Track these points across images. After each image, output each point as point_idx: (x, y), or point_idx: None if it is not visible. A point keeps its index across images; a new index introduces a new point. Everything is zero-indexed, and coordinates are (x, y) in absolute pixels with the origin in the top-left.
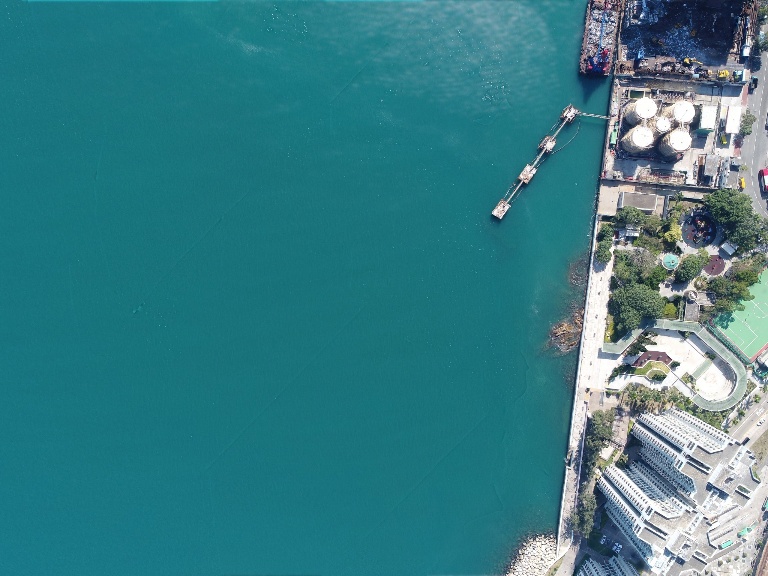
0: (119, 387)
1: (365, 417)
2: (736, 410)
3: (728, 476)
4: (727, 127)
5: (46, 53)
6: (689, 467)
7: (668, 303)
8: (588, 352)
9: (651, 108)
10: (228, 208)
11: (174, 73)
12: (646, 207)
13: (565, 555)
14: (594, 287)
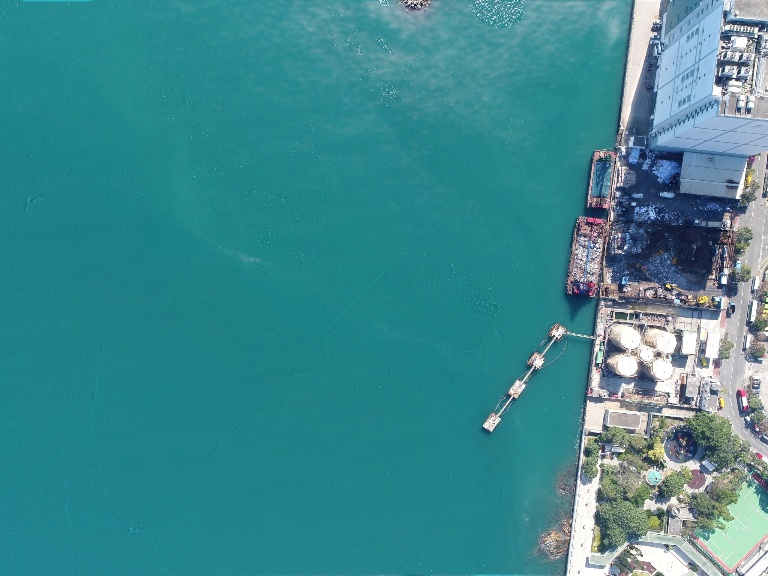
0: None
1: None
2: None
3: None
4: (707, 352)
5: (45, 274)
6: None
7: (652, 516)
8: (576, 561)
9: (635, 339)
10: (225, 432)
11: (171, 276)
12: (631, 426)
13: None
14: (581, 499)
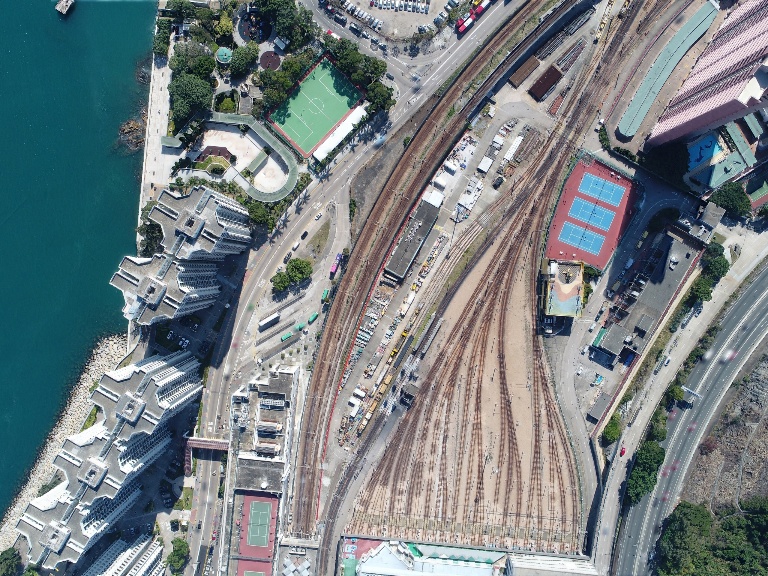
0: None
1: None
2: (294, 204)
3: (188, 218)
4: None
5: None
6: (158, 213)
7: (226, 98)
8: (152, 148)
9: None
10: None
11: None
12: (198, 0)
13: (134, 352)
14: (157, 83)
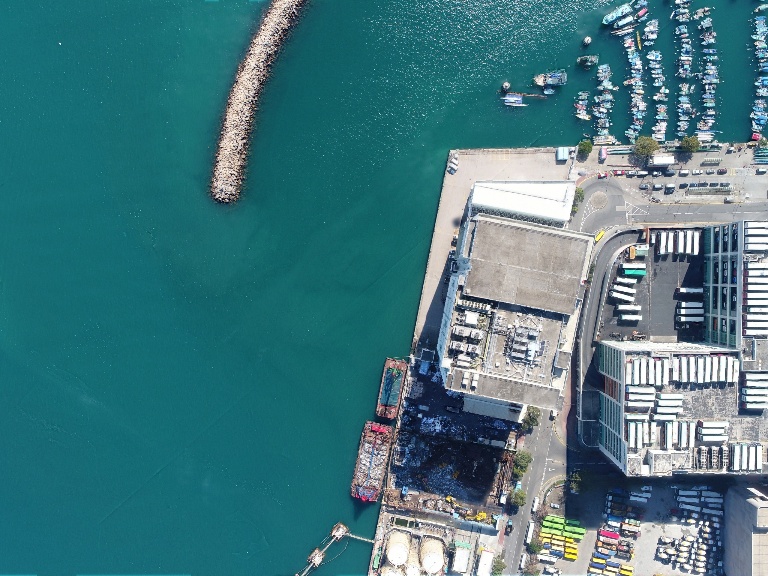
0: None
1: None
2: None
3: None
4: (479, 570)
5: None
6: None
7: None
8: None
9: (402, 556)
10: None
11: None
12: None
13: None
14: None
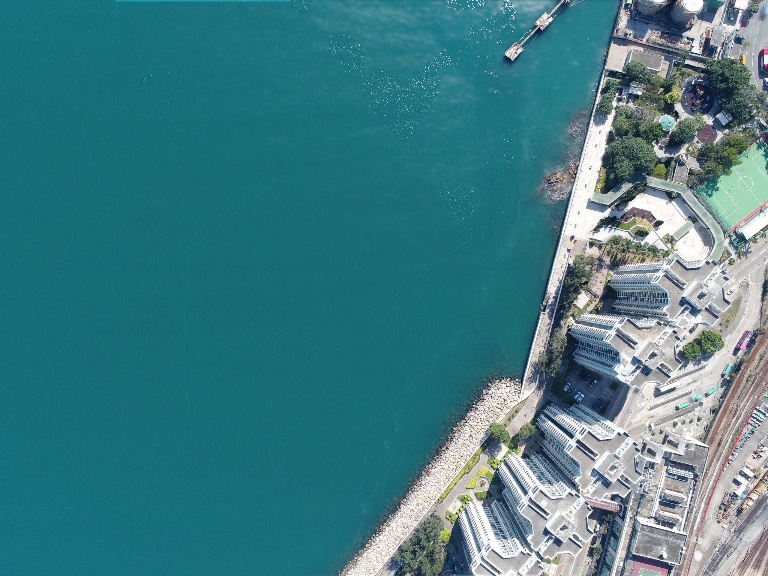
0: (108, 172)
1: (354, 222)
2: None
3: (702, 290)
4: (736, 2)
5: None
6: (666, 280)
7: (660, 164)
8: (578, 201)
9: None
10: None
11: None
12: (652, 67)
13: (528, 398)
14: (592, 139)
